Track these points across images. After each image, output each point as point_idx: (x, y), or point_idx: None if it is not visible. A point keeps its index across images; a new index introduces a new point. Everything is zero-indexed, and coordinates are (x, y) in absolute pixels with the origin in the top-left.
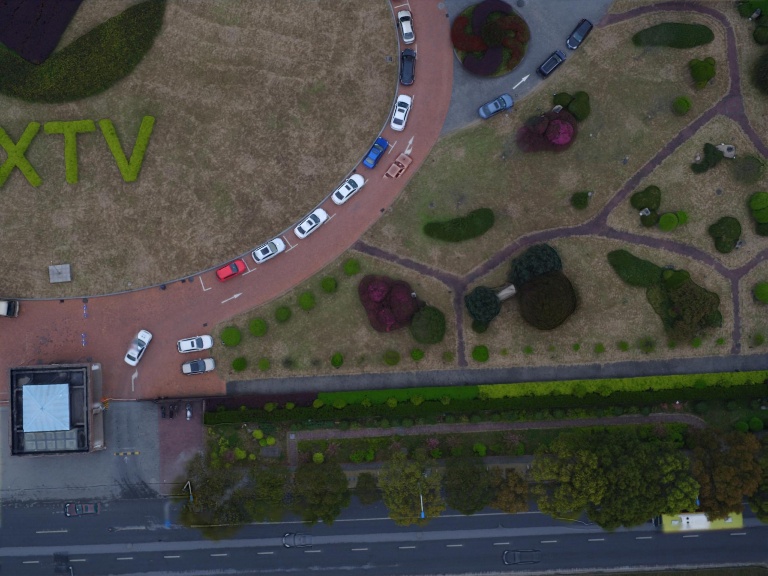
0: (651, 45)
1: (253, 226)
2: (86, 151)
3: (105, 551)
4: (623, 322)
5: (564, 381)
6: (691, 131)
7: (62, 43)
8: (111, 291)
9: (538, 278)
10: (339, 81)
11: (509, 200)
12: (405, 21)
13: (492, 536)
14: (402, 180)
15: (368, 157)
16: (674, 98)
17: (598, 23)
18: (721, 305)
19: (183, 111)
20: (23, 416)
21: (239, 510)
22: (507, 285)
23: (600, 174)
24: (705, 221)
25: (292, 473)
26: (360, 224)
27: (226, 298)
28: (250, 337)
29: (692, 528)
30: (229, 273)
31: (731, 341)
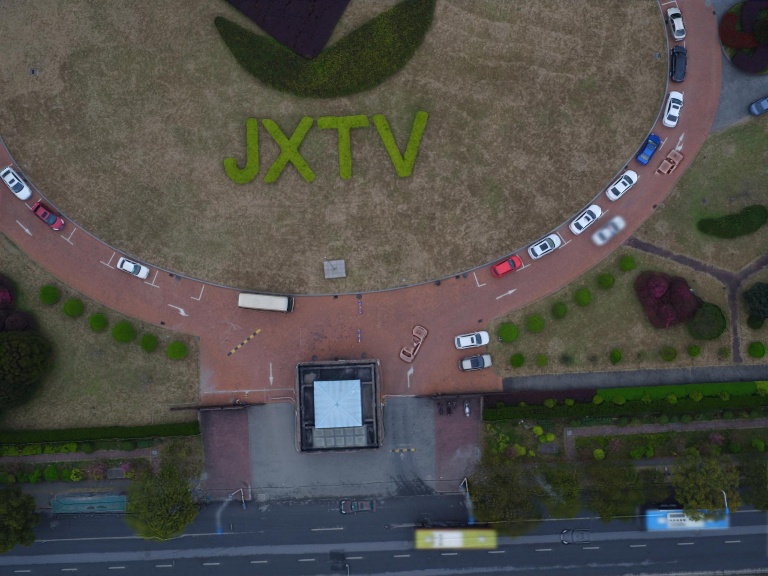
0: None
1: (527, 222)
2: (359, 146)
3: (382, 548)
4: None
5: None
6: None
7: (332, 38)
8: (385, 287)
9: None
10: (609, 77)
11: None
12: (677, 18)
13: None
14: (674, 176)
15: (643, 153)
16: None
17: None
18: None
19: (455, 107)
20: (315, 412)
21: (516, 507)
22: None
23: None
24: None
25: (574, 469)
26: (633, 220)
27: (500, 294)
28: (526, 333)
29: None
30: (507, 269)
31: None
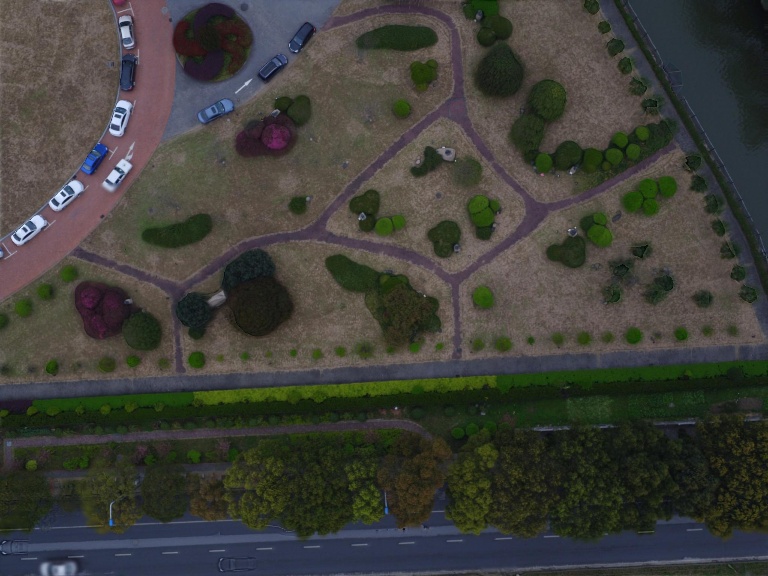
0: (374, 48)
1: None
2: None
3: None
4: (342, 327)
5: (280, 387)
6: (413, 134)
7: None
8: None
9: (242, 284)
10: (60, 87)
11: (228, 205)
12: (124, 26)
13: (208, 543)
14: (122, 186)
15: (84, 163)
16: (396, 101)
17: (322, 26)
18: (441, 310)
19: None
20: None
21: None
22: (218, 291)
23: (320, 178)
24: (425, 225)
25: (4, 481)
26: (79, 230)
27: None
28: None
29: (408, 535)
30: None
31: (452, 346)
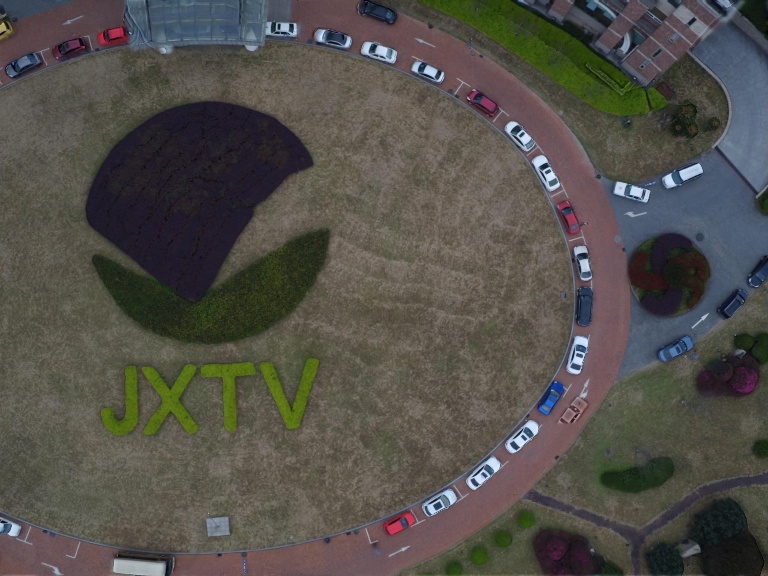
0: None
1: (422, 475)
2: (245, 395)
3: None
4: None
5: None
6: None
7: (218, 278)
8: (272, 544)
9: (728, 543)
10: (512, 320)
11: (689, 448)
12: (583, 259)
13: None
14: (577, 426)
15: (545, 405)
16: None
17: None
18: None
19: (348, 352)
20: None
21: None
22: (691, 544)
23: None
24: None
25: None
26: (534, 472)
27: (394, 551)
28: None
29: None
30: (400, 529)
31: None
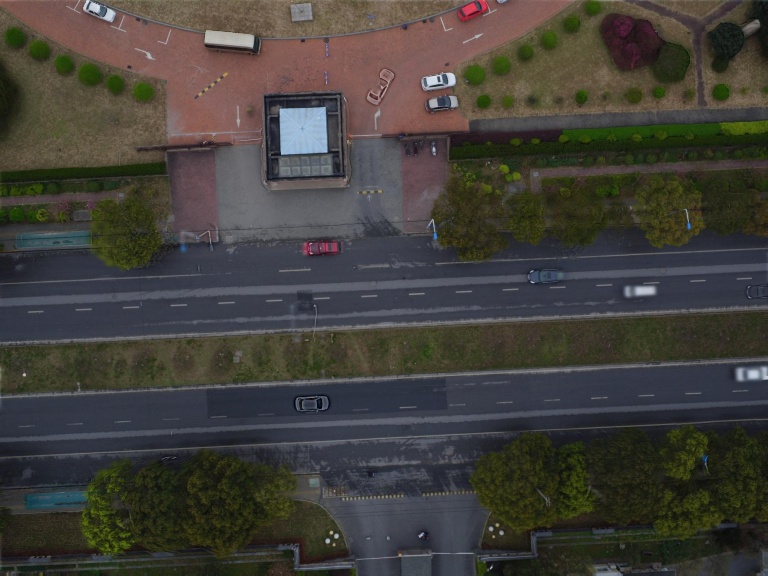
0: None
1: None
2: None
3: (349, 289)
4: None
5: None
6: None
7: None
8: (352, 31)
9: None
10: None
11: None
12: None
13: (735, 271)
14: None
15: None
16: None
17: None
18: None
19: None
20: (280, 139)
21: (484, 247)
22: (750, 21)
23: None
24: None
25: (541, 206)
26: None
27: (467, 38)
28: (492, 76)
29: None
30: (473, 10)
31: None
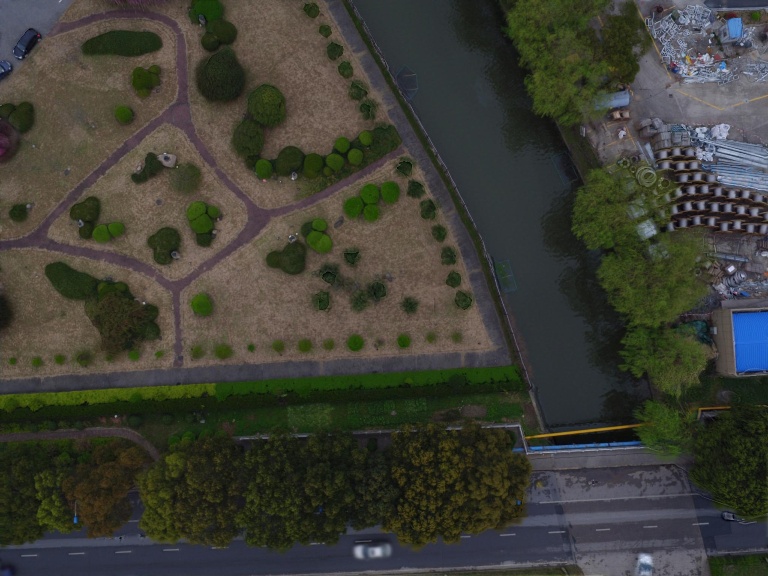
0: (99, 54)
1: None
2: None
3: None
4: (62, 335)
5: None
6: (136, 140)
7: None
8: None
9: None
10: None
11: None
12: None
13: None
14: None
15: None
16: (120, 107)
17: (49, 32)
18: (161, 317)
19: None
20: None
21: None
22: None
23: (41, 186)
24: (146, 232)
25: None
26: None
27: None
28: None
29: (124, 544)
30: None
31: (173, 354)
